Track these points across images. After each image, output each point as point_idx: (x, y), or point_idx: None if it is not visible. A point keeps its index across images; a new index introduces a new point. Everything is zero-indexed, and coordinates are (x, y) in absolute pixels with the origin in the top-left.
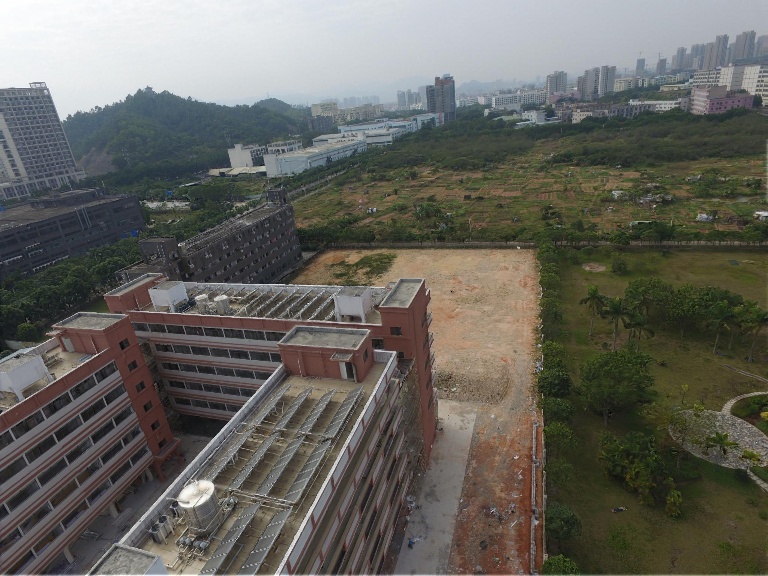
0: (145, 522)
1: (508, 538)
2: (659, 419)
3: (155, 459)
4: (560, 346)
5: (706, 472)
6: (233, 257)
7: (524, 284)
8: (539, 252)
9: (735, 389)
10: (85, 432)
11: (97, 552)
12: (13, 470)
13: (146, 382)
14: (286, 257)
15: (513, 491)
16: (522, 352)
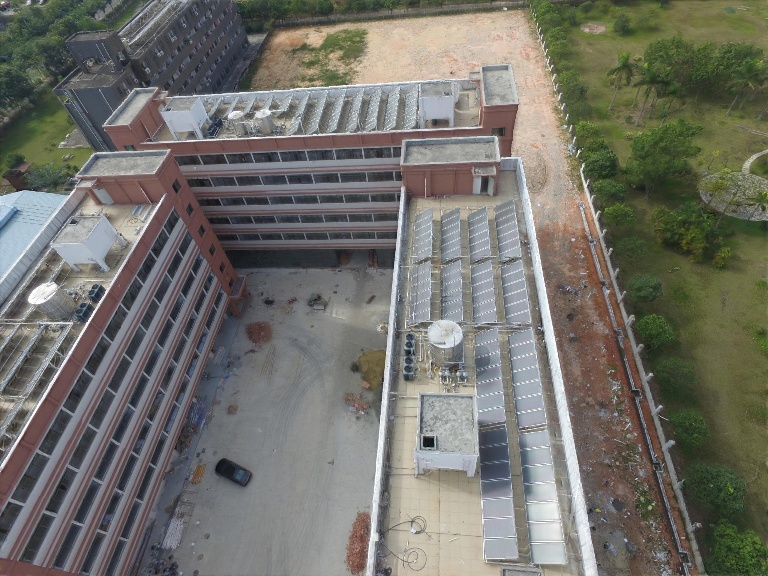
0: (390, 366)
1: (588, 308)
2: (691, 186)
3: (231, 299)
4: (595, 125)
5: (738, 227)
6: (184, 52)
7: (526, 56)
8: (538, 13)
9: (750, 149)
10: (176, 289)
11: (215, 389)
12: (137, 341)
13: (204, 225)
14: (234, 45)
15: (580, 269)
16: (550, 136)
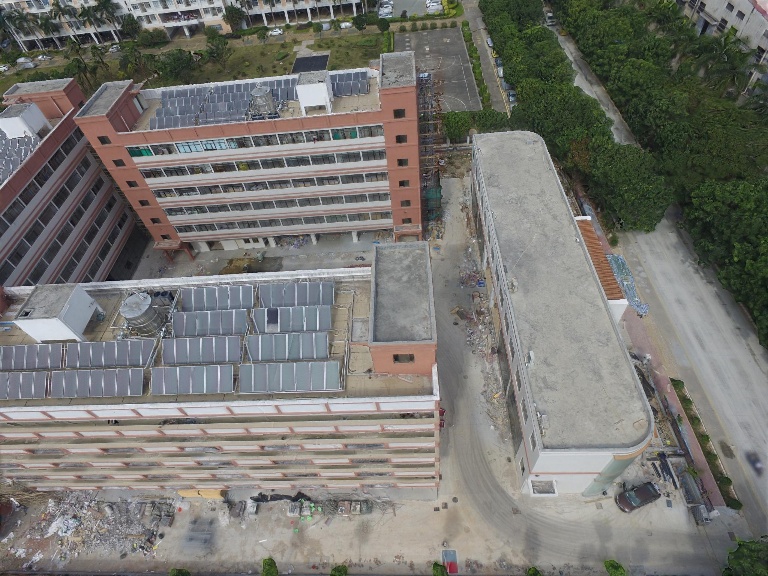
0: None
1: None
2: None
3: None
4: None
5: None
6: None
7: None
8: None
9: None
10: None
11: None
12: None
13: None
14: None
15: None
16: None
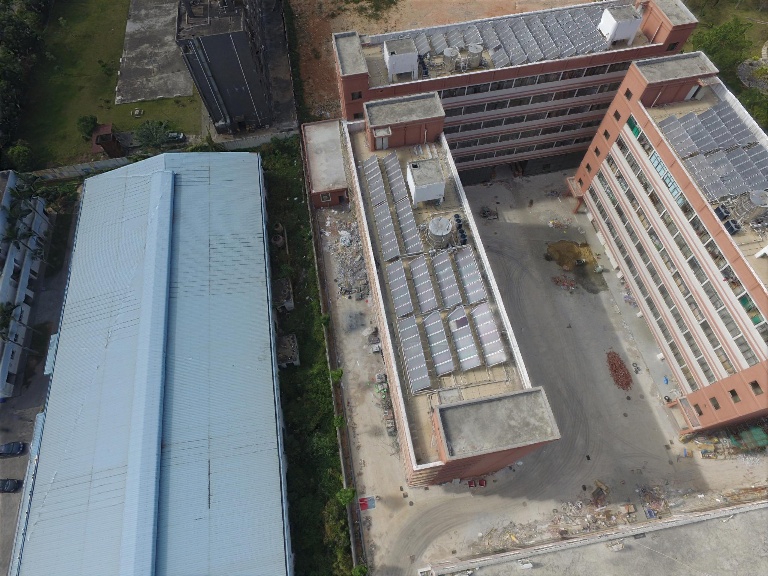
0: None
1: None
2: (732, 74)
3: None
4: None
5: None
6: None
7: None
8: None
9: (762, 37)
10: None
11: None
12: None
13: None
14: None
15: None
16: None
